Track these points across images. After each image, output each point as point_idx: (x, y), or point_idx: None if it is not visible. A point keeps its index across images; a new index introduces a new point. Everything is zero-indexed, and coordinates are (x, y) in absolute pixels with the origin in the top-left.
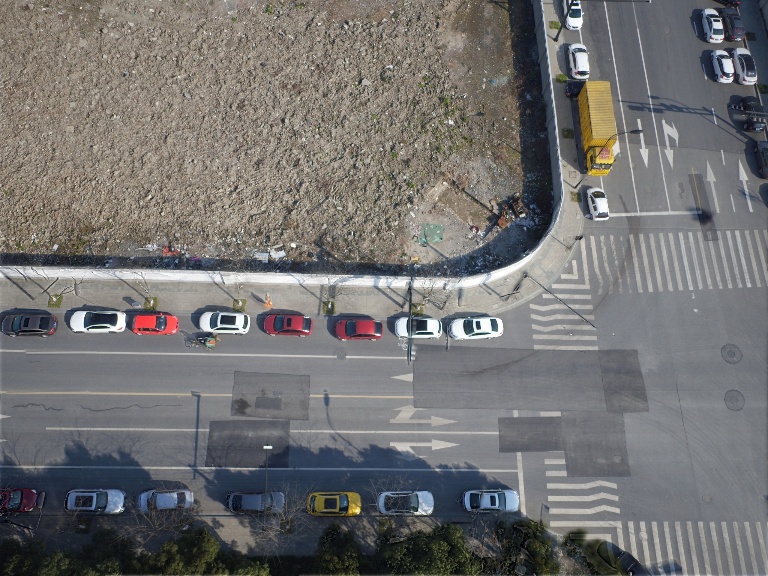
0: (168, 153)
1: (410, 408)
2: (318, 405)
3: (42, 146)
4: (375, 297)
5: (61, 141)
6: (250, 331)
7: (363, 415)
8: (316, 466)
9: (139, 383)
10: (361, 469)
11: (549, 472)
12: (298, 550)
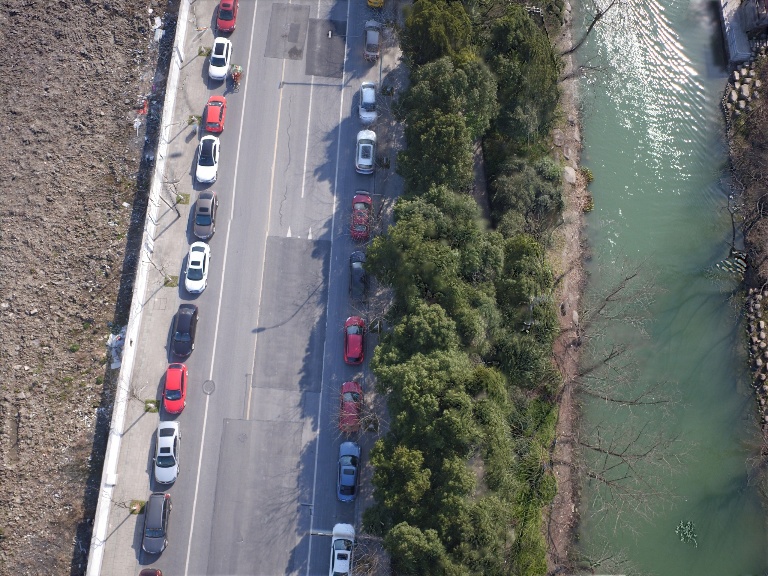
0: (33, 112)
1: None
2: None
3: (5, 225)
4: None
5: (2, 208)
6: None
7: None
8: (347, 3)
9: (268, 128)
10: None
11: None
12: (408, 16)
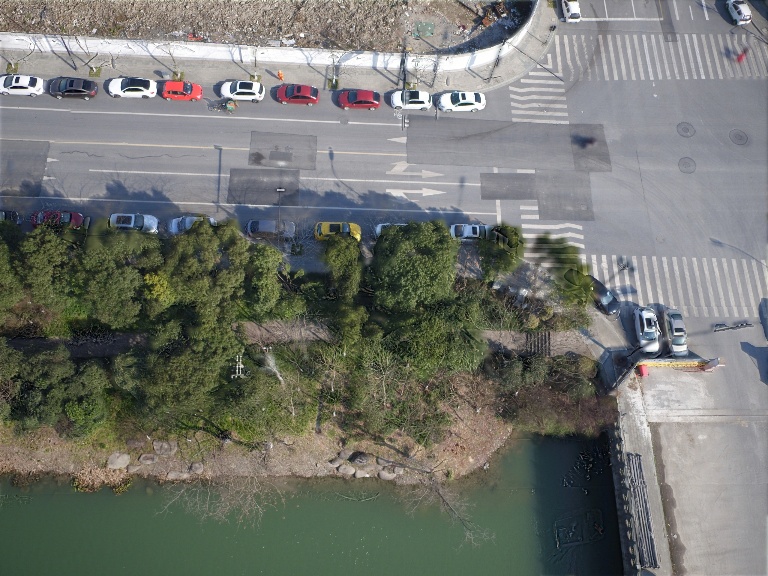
0: None
1: (404, 163)
2: (324, 159)
3: None
4: (374, 76)
5: None
6: (265, 99)
7: (363, 167)
8: (322, 205)
9: (169, 138)
10: (361, 209)
11: (524, 216)
12: (307, 268)
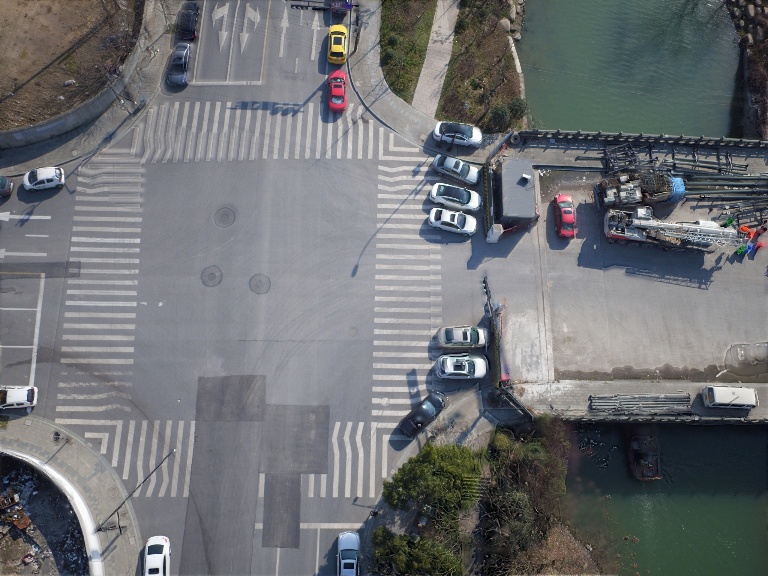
0: None
1: None
2: None
3: None
4: None
5: None
6: None
7: None
8: None
9: None
10: None
11: (322, 493)
12: None
